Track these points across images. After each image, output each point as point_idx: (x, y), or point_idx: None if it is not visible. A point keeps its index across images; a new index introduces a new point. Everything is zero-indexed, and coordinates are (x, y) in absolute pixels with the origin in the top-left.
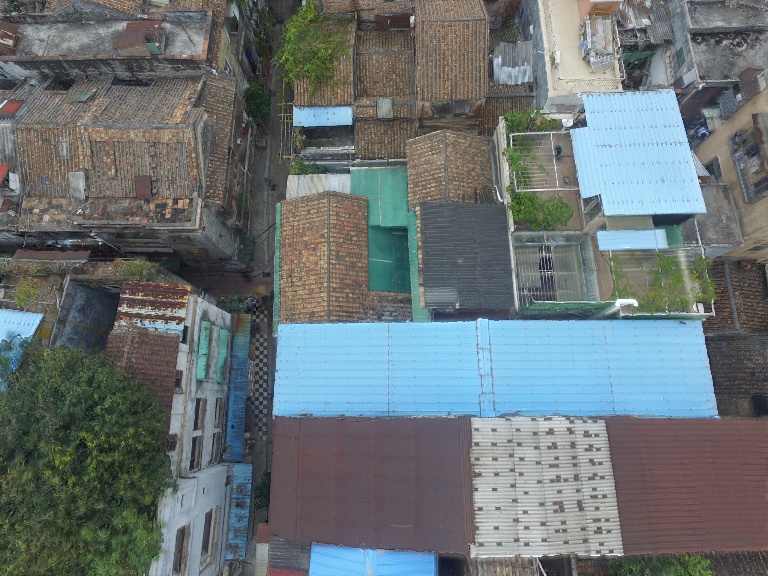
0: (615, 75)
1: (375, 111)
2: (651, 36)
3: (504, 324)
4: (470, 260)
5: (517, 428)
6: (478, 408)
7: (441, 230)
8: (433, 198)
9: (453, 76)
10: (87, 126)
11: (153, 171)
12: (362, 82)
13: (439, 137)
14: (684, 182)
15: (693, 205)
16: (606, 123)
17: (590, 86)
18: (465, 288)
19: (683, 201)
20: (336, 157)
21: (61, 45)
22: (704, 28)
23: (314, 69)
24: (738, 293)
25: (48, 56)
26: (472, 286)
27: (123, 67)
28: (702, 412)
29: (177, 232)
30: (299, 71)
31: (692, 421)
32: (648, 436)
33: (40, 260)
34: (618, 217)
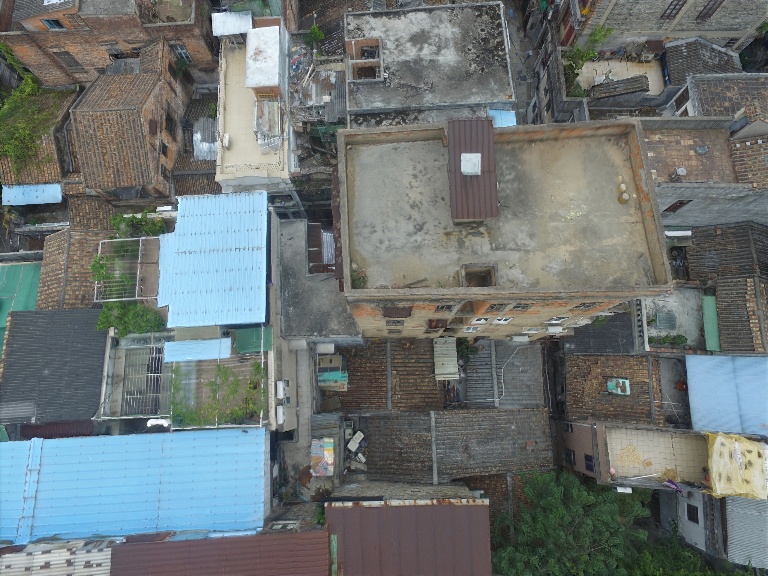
0: (283, 156)
1: (84, 188)
2: (326, 114)
3: (60, 442)
4: (57, 370)
5: (7, 565)
6: (16, 533)
7: (31, 340)
8: (52, 300)
9: (114, 164)
10: None
11: None
12: (76, 157)
13: (65, 236)
14: (251, 290)
15: (253, 314)
16: (192, 228)
17: (250, 170)
18: (46, 400)
19: (245, 310)
20: None
21: None
22: (361, 110)
23: (13, 149)
24: (395, 372)
25: None
26: (54, 398)
27: None
28: (246, 524)
29: None
30: None
31: (211, 541)
32: (158, 561)
33: None
34: (183, 328)
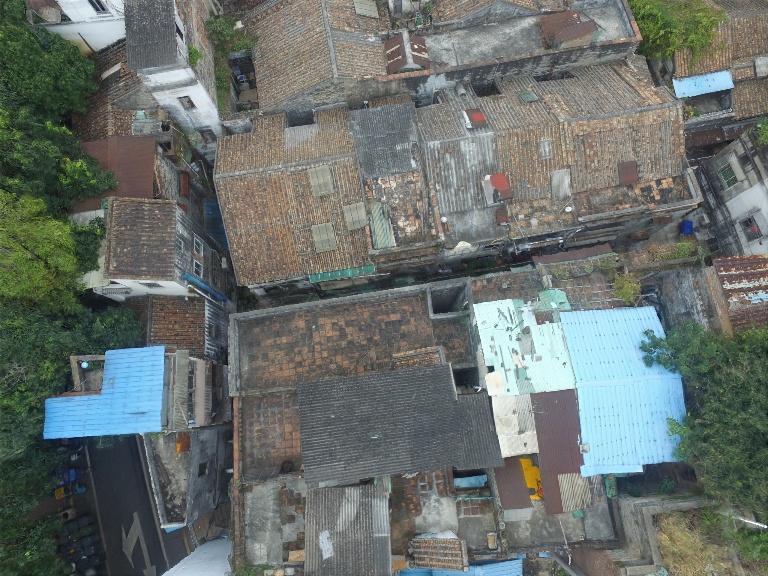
0: None
1: (752, 71)
2: None
3: None
4: None
5: None
6: None
7: None
8: None
9: None
10: (570, 121)
11: (636, 156)
12: None
13: None
14: None
15: None
16: None
17: None
18: None
19: None
20: (710, 123)
21: (472, 51)
22: None
23: (700, 38)
24: None
25: (483, 61)
26: None
27: (550, 62)
28: None
29: (673, 211)
30: (682, 43)
31: None
32: None
33: (567, 261)
34: None
